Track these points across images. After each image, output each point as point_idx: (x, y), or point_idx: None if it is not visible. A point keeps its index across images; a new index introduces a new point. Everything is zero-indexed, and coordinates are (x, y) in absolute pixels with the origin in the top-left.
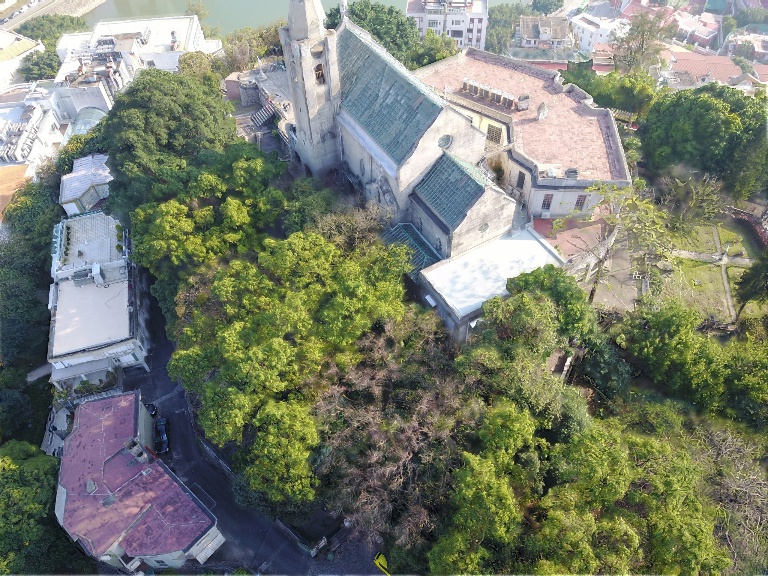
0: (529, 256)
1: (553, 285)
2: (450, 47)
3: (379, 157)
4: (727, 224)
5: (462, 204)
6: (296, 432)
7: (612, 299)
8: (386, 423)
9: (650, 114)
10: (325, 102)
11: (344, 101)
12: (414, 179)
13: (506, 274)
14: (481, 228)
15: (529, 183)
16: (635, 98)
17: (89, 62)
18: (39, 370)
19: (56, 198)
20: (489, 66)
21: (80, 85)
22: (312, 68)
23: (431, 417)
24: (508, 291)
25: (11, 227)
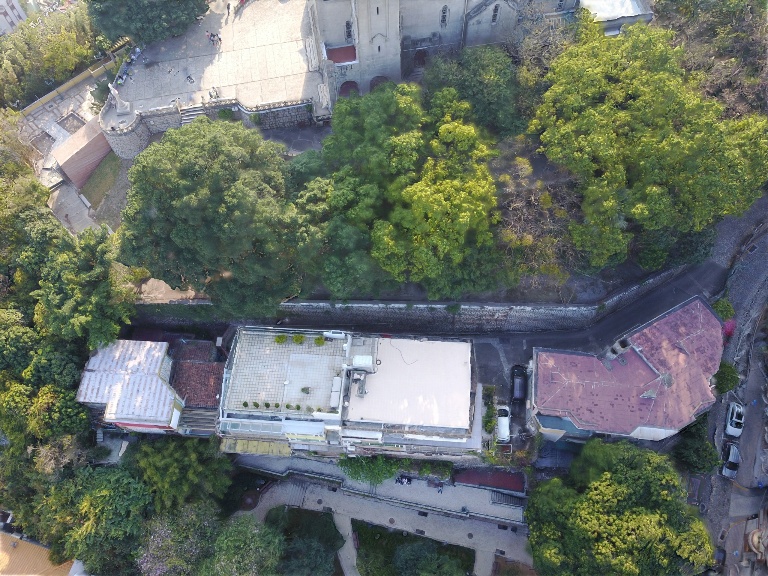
0: None
1: None
2: None
3: None
4: None
5: None
6: (764, 127)
7: None
8: (748, 82)
9: None
10: None
11: None
12: None
13: None
14: None
15: None
16: None
17: None
18: (340, 549)
19: (103, 460)
20: None
21: None
22: None
23: None
24: None
25: (99, 551)
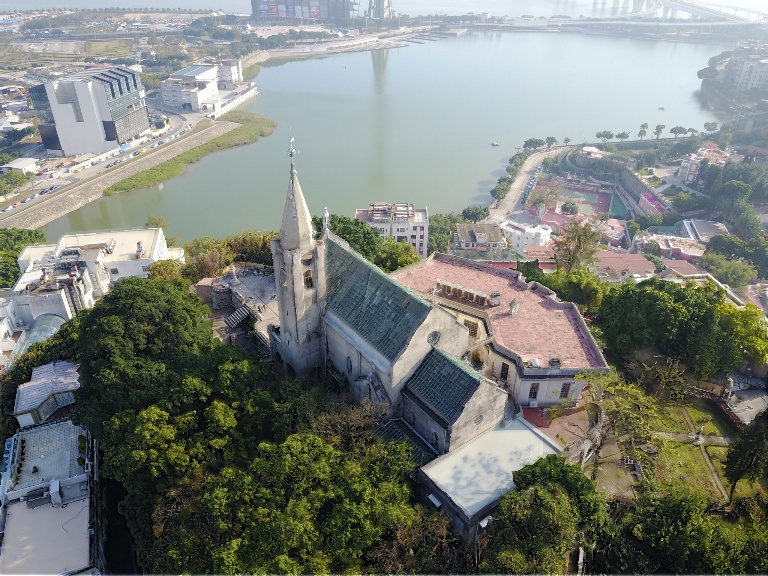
0: (525, 446)
1: (560, 476)
2: (409, 251)
3: (369, 354)
4: (693, 404)
5: (458, 397)
6: None
7: (610, 486)
8: None
9: (603, 306)
10: (312, 304)
11: (330, 303)
12: (406, 374)
13: (506, 466)
14: (476, 420)
15: (513, 373)
16: (582, 292)
17: (51, 271)
18: None
19: (7, 409)
20: (456, 268)
21: (41, 293)
22: (302, 274)
23: None
24: (516, 485)
25: None
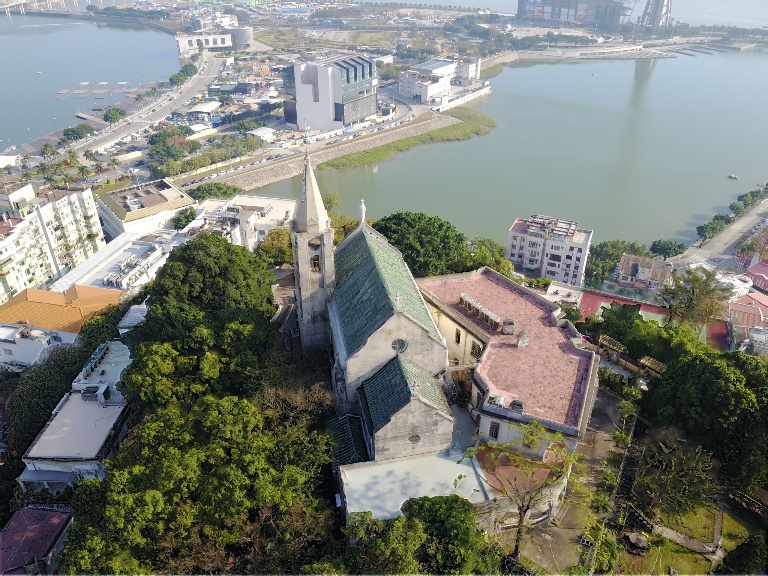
0: None
1: None
2: (500, 266)
3: (341, 346)
4: (737, 513)
5: (391, 409)
6: None
7: (547, 559)
8: None
9: (667, 369)
10: (319, 288)
11: (336, 291)
12: (364, 374)
13: (424, 494)
14: (411, 438)
15: None
16: (673, 351)
17: (214, 222)
18: None
19: None
20: (498, 288)
21: None
22: (308, 257)
23: None
24: (402, 511)
25: (83, 338)
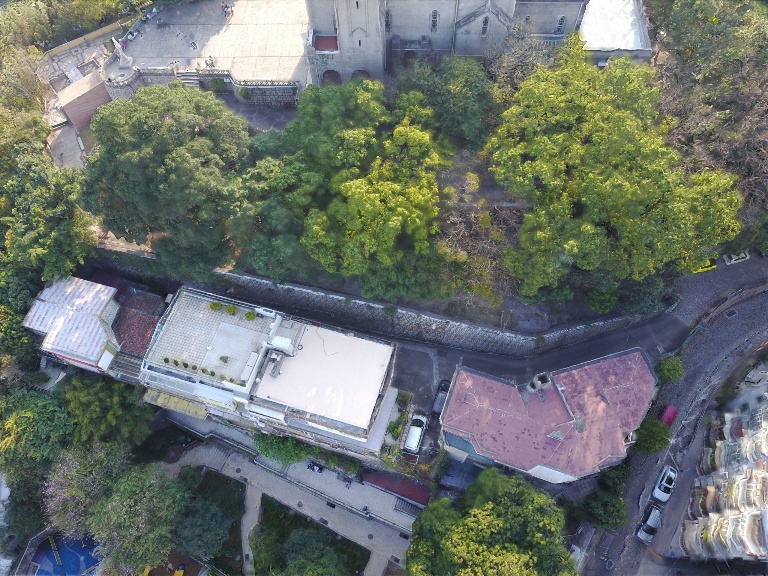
0: None
1: None
2: None
3: None
4: None
5: None
6: (725, 186)
7: None
8: (729, 136)
9: None
10: None
11: None
12: None
13: (614, 7)
14: None
15: None
16: None
17: None
18: (245, 520)
19: (39, 385)
20: None
21: None
22: None
23: (763, 97)
24: None
25: (18, 467)
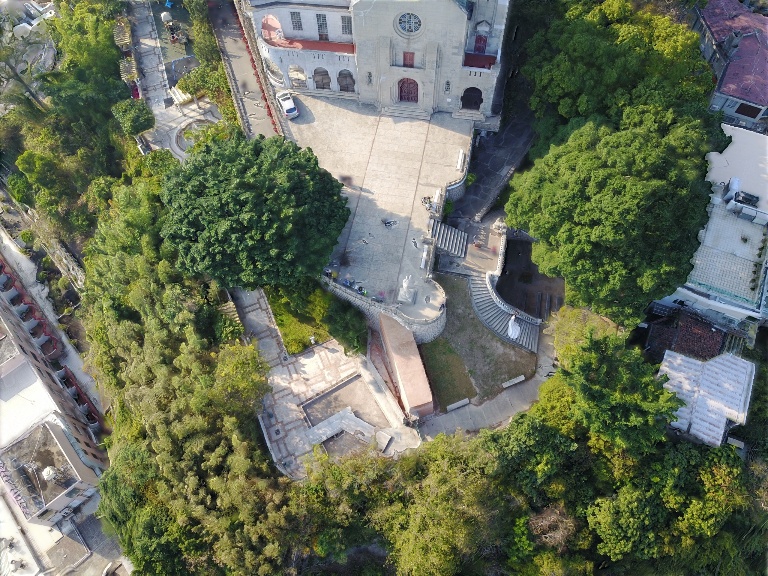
0: None
1: None
2: None
3: None
4: None
5: None
6: None
7: None
8: None
9: None
10: None
11: None
12: None
13: None
14: None
15: None
16: None
17: None
18: None
19: (748, 463)
20: None
21: None
22: None
23: None
24: None
25: None
